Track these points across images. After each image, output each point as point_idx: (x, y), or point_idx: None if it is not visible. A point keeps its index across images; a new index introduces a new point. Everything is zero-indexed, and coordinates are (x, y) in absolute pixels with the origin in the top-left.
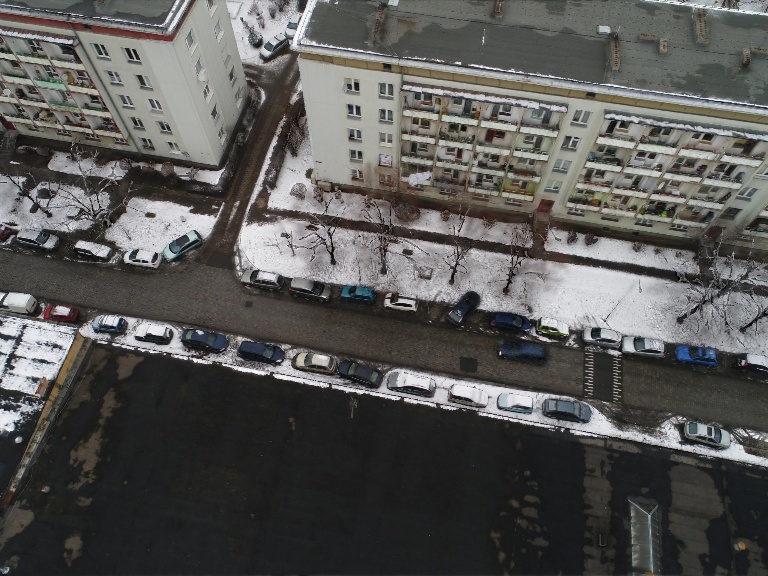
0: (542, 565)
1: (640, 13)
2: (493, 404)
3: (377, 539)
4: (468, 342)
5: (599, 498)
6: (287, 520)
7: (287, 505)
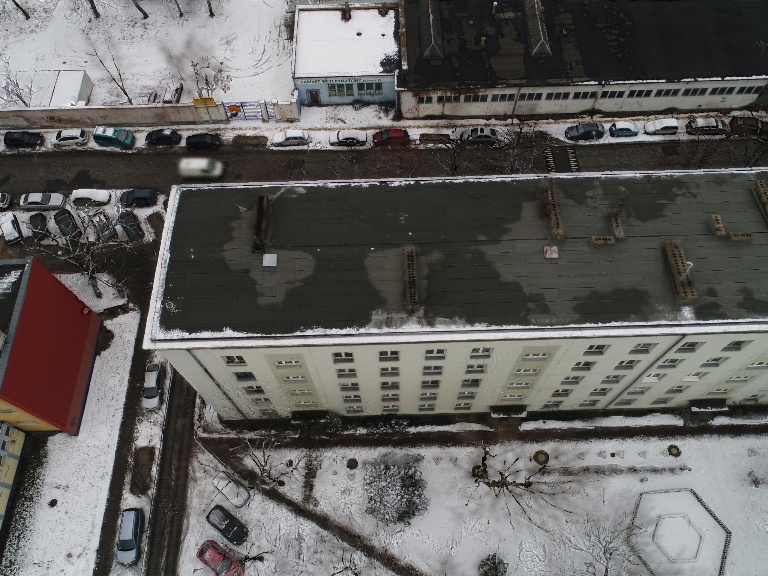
0: (597, 16)
1: (761, 289)
2: (640, 129)
3: (697, 8)
4: (678, 166)
5: (570, 51)
6: (755, 6)
7: (760, 13)
